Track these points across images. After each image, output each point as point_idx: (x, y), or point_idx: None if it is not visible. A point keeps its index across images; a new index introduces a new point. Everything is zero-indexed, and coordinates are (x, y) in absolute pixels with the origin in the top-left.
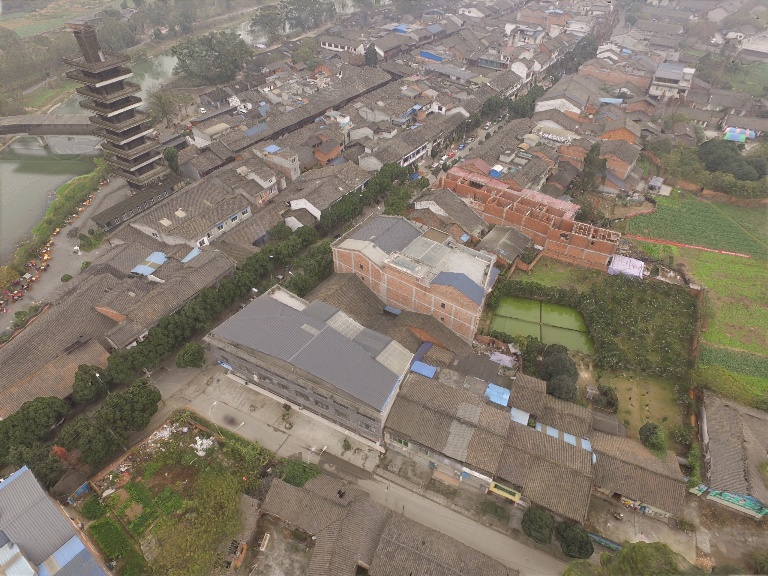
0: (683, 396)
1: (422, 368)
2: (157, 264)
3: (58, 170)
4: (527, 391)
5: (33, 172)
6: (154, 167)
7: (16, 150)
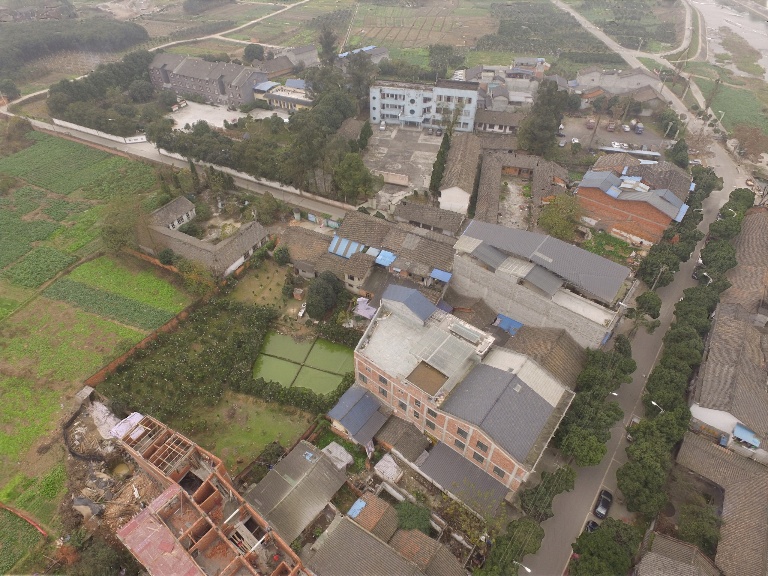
0: (231, 283)
1: (442, 275)
2: None
3: None
4: (364, 257)
5: None
6: None
7: None
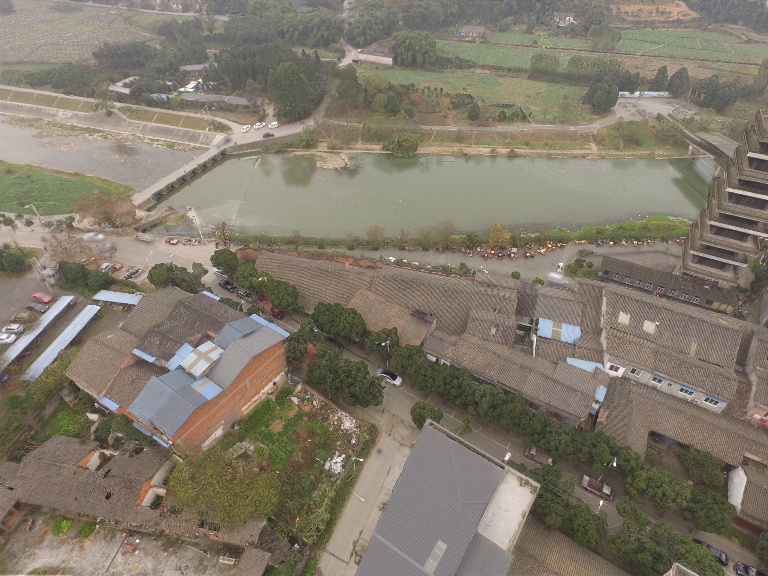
0: None
1: None
2: (560, 336)
3: (685, 202)
4: None
5: (667, 189)
6: (725, 269)
7: (692, 165)
